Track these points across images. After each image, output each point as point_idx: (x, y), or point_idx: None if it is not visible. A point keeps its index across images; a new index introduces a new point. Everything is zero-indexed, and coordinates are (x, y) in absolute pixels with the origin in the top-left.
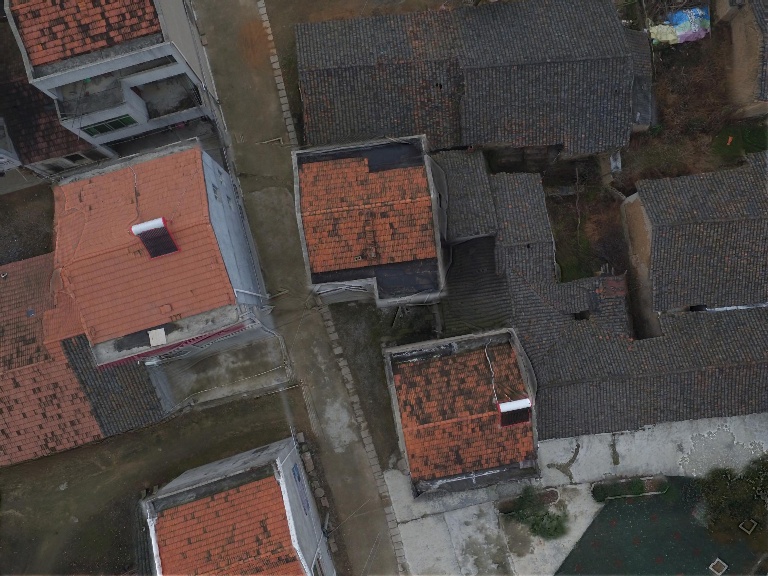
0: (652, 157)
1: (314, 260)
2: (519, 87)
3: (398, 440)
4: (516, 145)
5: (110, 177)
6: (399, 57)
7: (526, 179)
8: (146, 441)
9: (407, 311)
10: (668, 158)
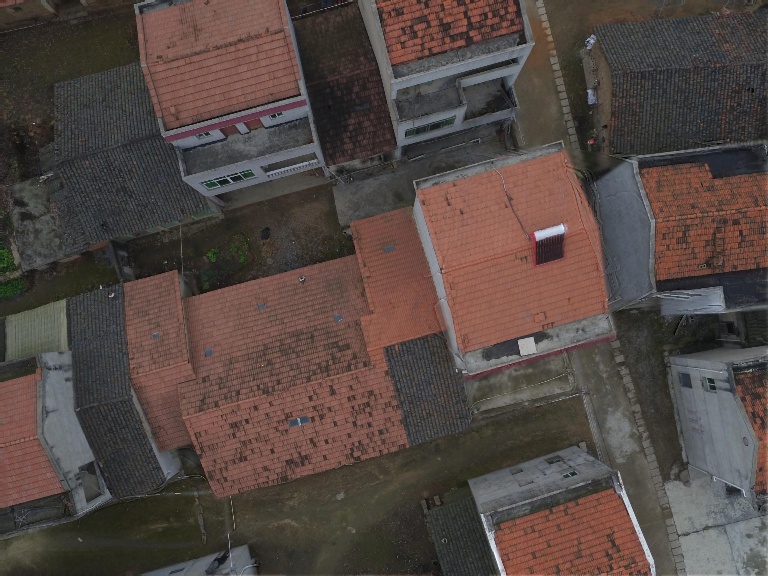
0: None
1: (658, 267)
2: None
3: (681, 451)
4: None
5: (471, 180)
6: (714, 60)
7: None
8: (424, 450)
9: (691, 319)
10: None
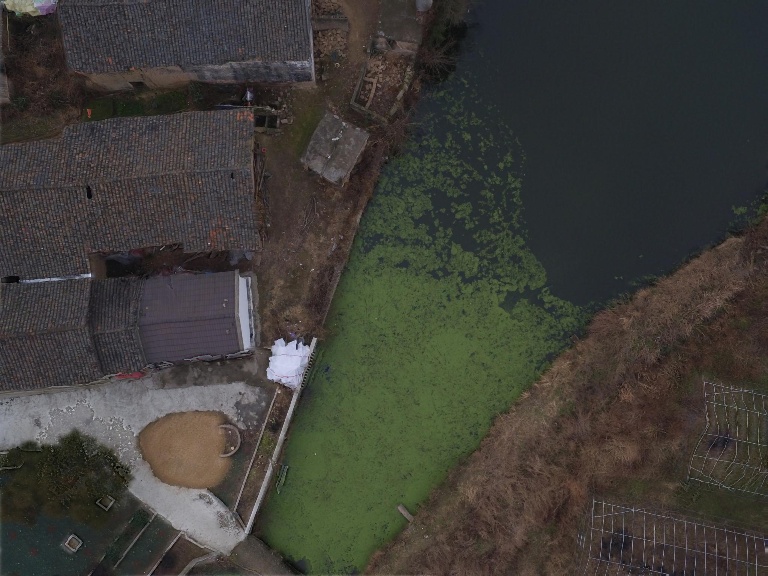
0: (22, 130)
1: None
2: None
3: None
4: None
5: None
6: None
7: None
8: None
9: None
10: (39, 131)
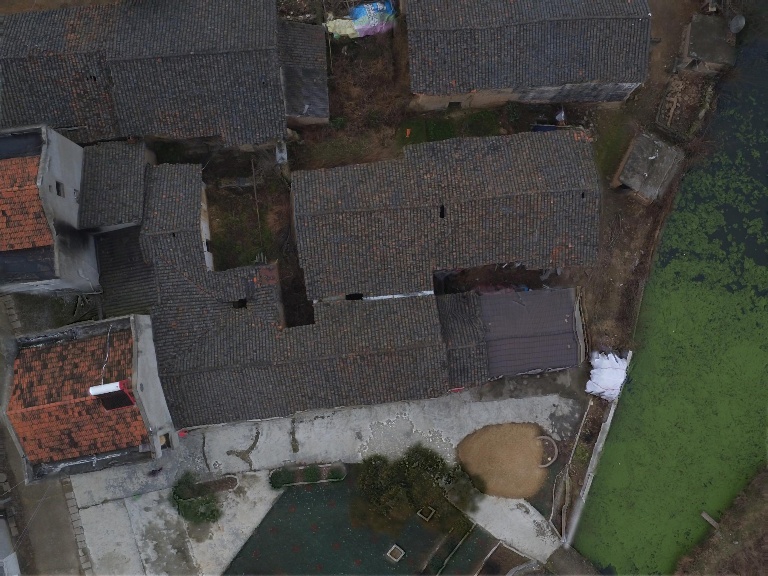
0: (337, 149)
1: None
2: (167, 79)
3: None
4: (174, 136)
5: None
6: (50, 50)
7: (186, 170)
8: None
9: (87, 300)
10: (353, 150)
